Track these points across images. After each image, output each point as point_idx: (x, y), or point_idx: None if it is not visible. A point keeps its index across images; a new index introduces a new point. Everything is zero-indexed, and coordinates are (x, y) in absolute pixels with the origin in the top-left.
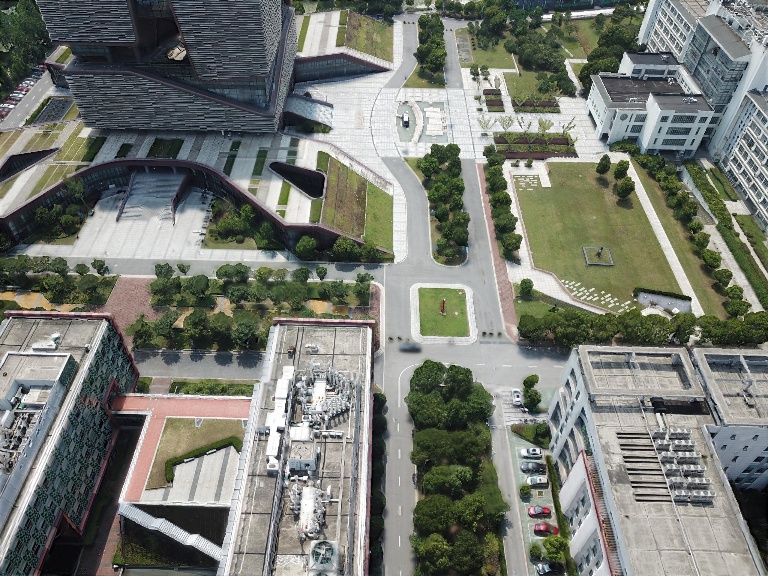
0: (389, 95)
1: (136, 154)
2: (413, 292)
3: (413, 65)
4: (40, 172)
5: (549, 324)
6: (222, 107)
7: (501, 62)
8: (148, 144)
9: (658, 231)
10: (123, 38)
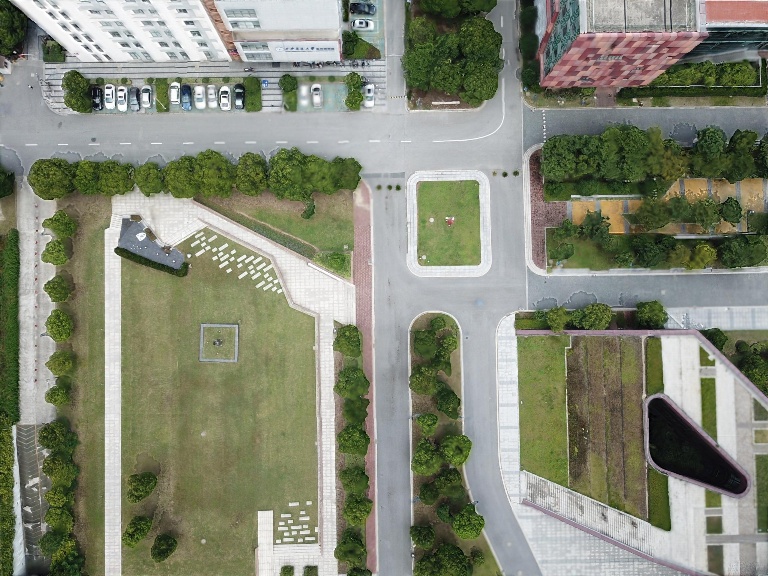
0: None
1: None
2: (488, 257)
3: None
4: None
5: (326, 163)
6: None
7: None
8: None
9: (115, 399)
10: None
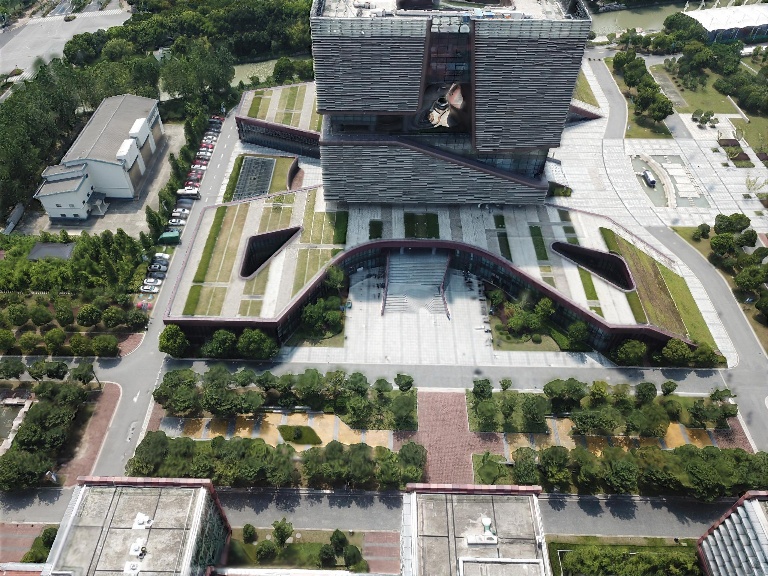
0: (615, 148)
1: (391, 233)
2: None
3: (624, 110)
4: (292, 258)
5: None
6: (492, 179)
7: (719, 106)
8: (399, 220)
9: None
10: (403, 106)
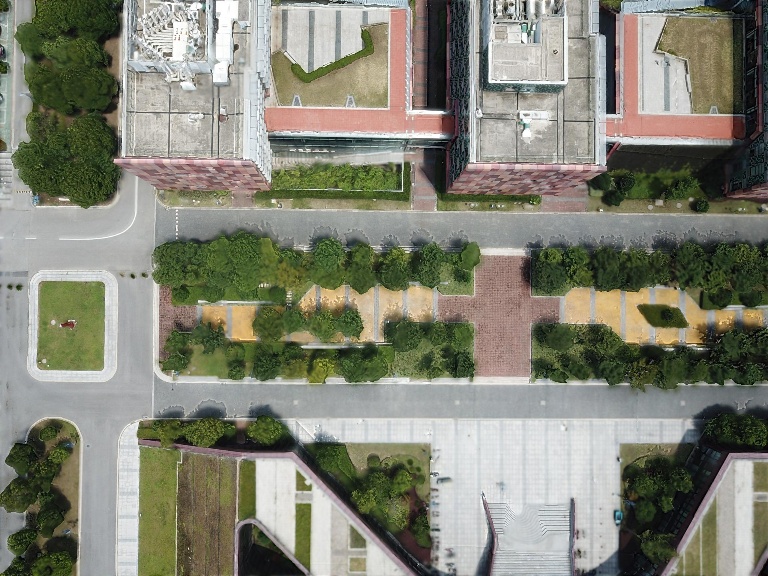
0: None
1: None
2: (112, 362)
3: None
4: None
5: None
6: None
7: None
8: None
9: None
10: None
